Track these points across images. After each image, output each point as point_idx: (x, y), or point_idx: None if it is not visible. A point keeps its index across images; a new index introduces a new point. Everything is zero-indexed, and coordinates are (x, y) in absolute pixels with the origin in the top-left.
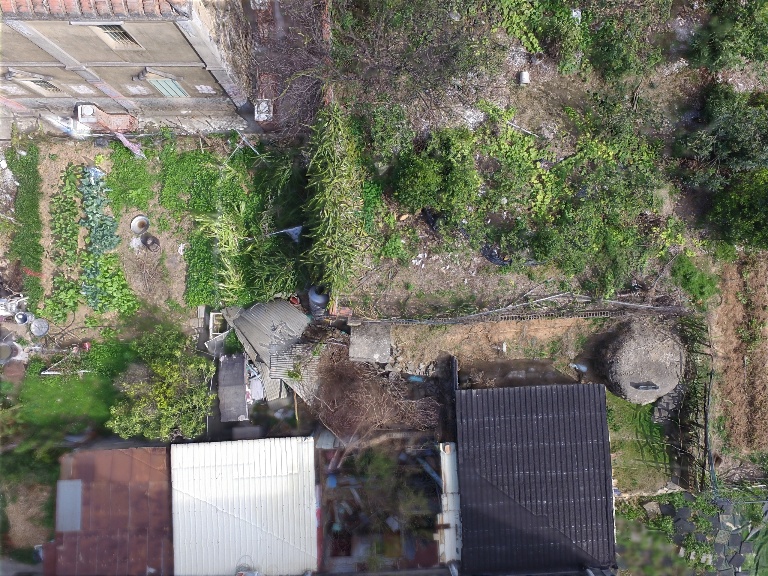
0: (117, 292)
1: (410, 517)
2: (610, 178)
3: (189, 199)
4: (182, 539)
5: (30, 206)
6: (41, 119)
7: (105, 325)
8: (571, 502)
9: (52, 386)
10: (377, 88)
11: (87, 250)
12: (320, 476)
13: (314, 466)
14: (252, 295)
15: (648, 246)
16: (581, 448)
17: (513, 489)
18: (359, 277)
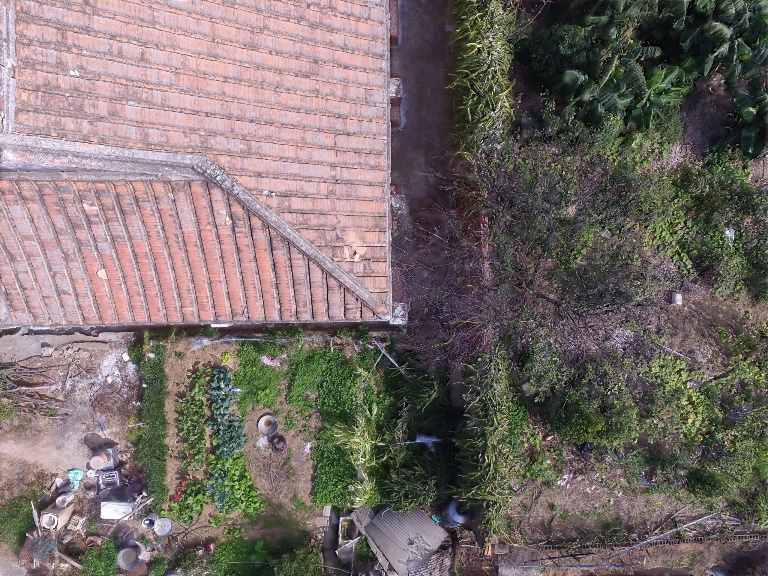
0: (245, 496)
1: None
2: None
3: (317, 397)
4: None
5: (157, 407)
6: None
7: (229, 523)
8: None
9: None
10: (524, 306)
11: (215, 454)
12: None
13: None
14: (382, 498)
15: None
16: None
17: None
18: None
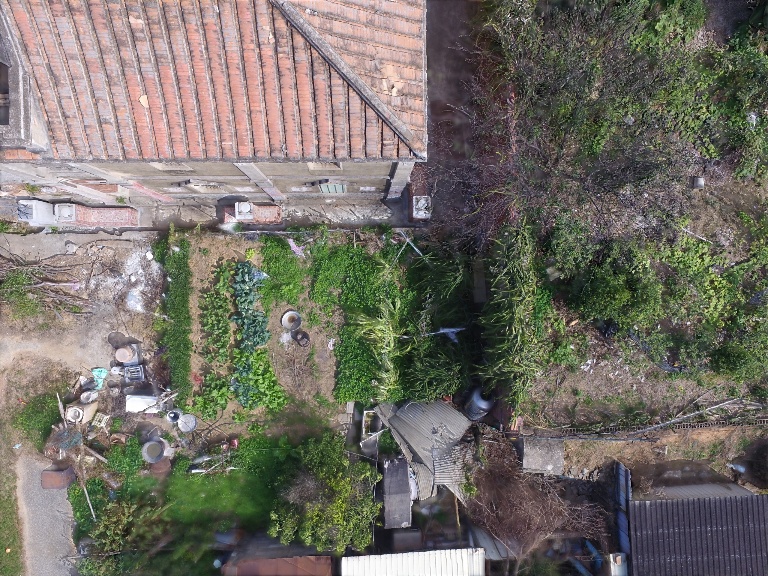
0: (269, 390)
1: None
2: None
3: (340, 294)
4: None
5: (181, 302)
6: (184, 207)
7: (252, 420)
8: None
9: (199, 483)
10: (548, 192)
11: (240, 347)
12: None
13: None
14: (405, 392)
15: None
16: (756, 561)
17: None
18: None
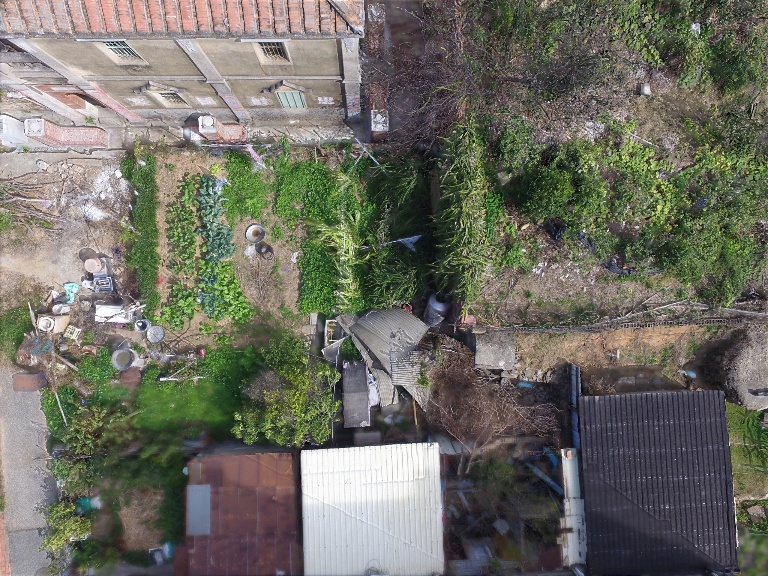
0: (234, 300)
1: (530, 521)
2: (734, 188)
3: (303, 208)
4: (311, 543)
5: (148, 215)
6: (152, 129)
7: (219, 332)
8: (693, 507)
9: (168, 392)
10: (499, 99)
11: (205, 258)
12: (445, 481)
13: (440, 471)
14: (366, 303)
15: (766, 255)
16: (702, 454)
17: (636, 494)
18: (481, 285)
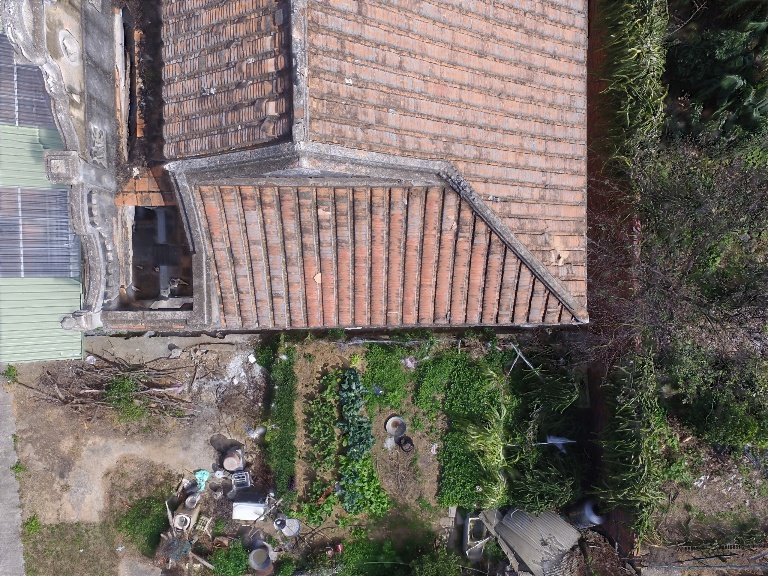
0: (375, 497)
1: None
2: None
3: (444, 399)
4: None
5: (287, 408)
6: None
7: (355, 524)
8: None
9: None
10: (663, 309)
11: (346, 455)
12: None
13: None
14: (509, 499)
15: None
16: None
17: None
18: None
